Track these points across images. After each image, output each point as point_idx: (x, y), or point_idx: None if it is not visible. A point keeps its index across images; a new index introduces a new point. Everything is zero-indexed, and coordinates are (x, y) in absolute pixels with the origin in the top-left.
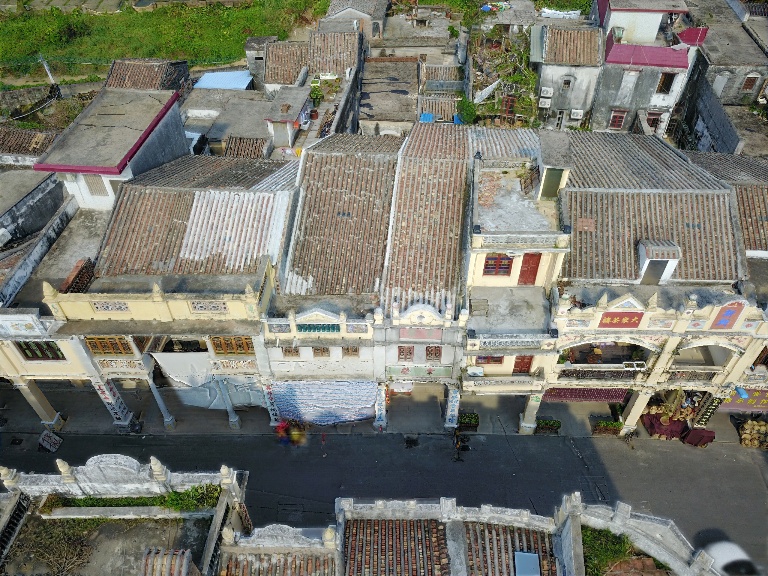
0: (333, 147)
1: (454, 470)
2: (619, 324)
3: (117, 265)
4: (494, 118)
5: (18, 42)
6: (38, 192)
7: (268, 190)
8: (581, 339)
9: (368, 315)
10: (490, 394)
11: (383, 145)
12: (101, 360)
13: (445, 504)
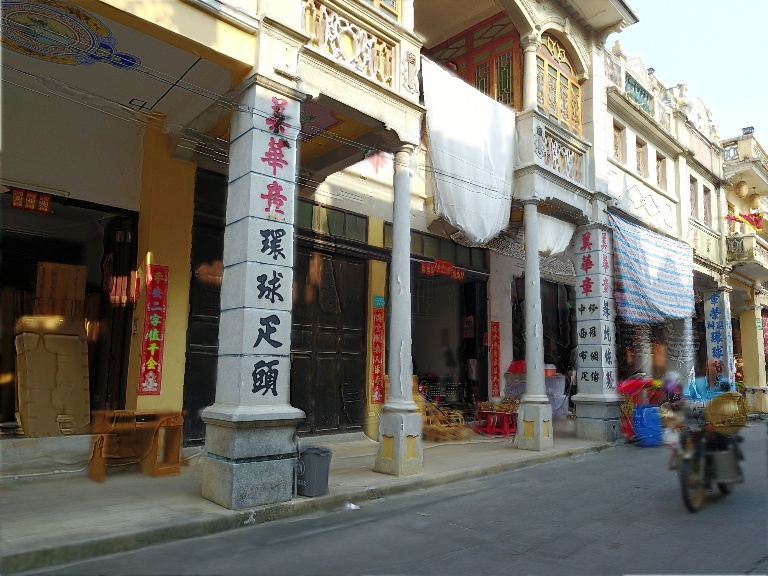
0: None
1: None
2: None
3: None
4: None
5: None
6: None
7: None
8: (757, 210)
9: (669, 92)
10: (767, 268)
11: None
12: None
13: None
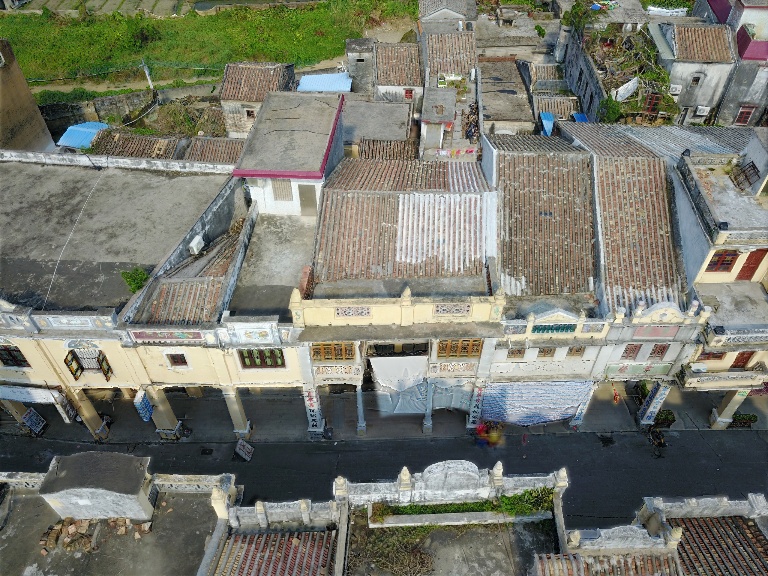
0: (513, 147)
1: (658, 467)
2: None
3: (335, 270)
4: (636, 116)
5: (89, 48)
6: (219, 198)
7: (472, 191)
8: None
9: (610, 314)
10: (711, 390)
11: (554, 144)
12: (321, 366)
13: (758, 500)
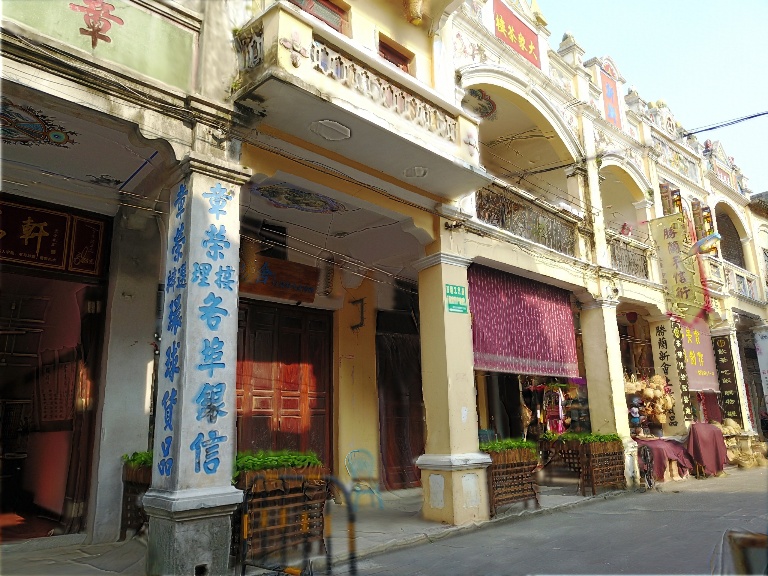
0: None
1: None
2: (517, 51)
3: None
4: None
5: None
6: None
7: None
8: None
9: None
10: (374, 122)
11: None
12: None
13: None
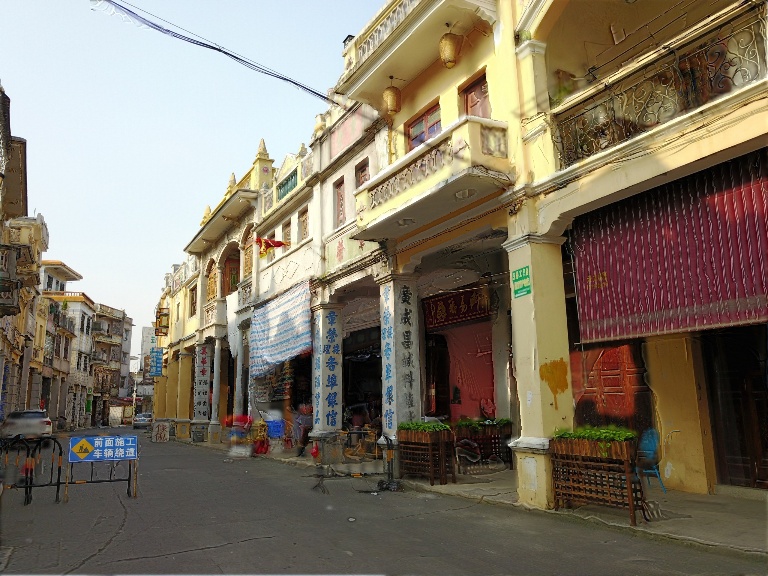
0: None
1: None
2: None
3: None
4: None
5: None
6: None
7: None
8: None
9: None
10: (384, 218)
11: None
12: None
13: None
